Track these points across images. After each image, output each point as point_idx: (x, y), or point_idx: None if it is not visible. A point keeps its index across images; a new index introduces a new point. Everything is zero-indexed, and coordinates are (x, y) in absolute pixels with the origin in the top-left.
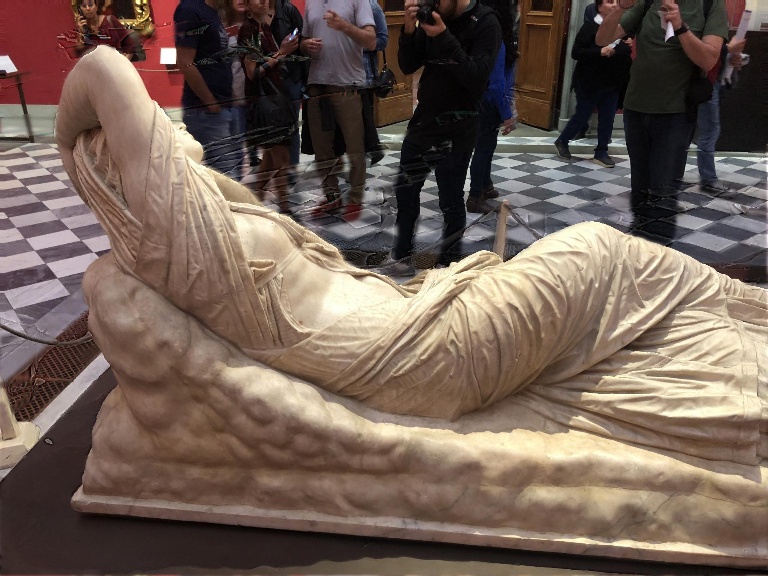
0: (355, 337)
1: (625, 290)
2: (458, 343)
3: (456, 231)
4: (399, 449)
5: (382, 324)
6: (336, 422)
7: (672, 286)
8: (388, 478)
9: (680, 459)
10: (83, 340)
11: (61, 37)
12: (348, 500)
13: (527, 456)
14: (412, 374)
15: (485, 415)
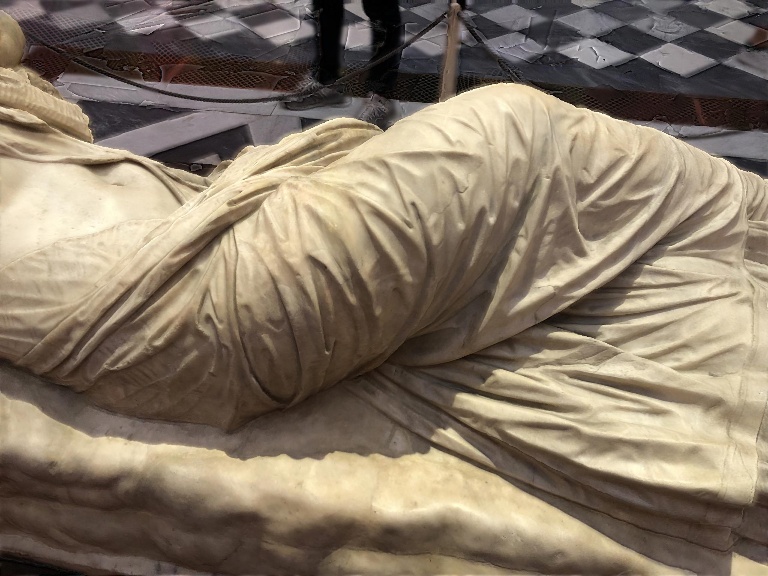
0: (37, 300)
1: (551, 225)
2: (216, 323)
3: (390, 51)
4: (124, 485)
5: (89, 277)
6: (9, 443)
7: (646, 216)
8: (123, 513)
9: (598, 526)
10: None
11: None
12: (69, 535)
13: (336, 509)
14: (143, 367)
15: (293, 418)
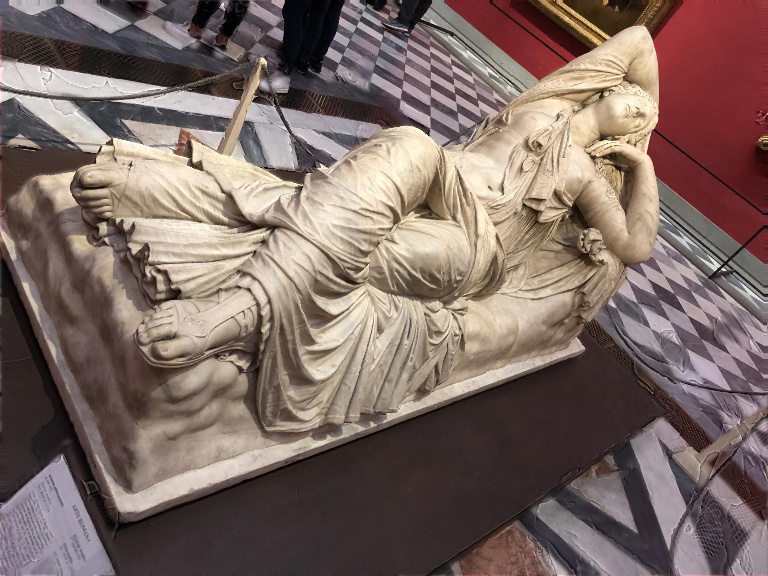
0: None
1: None
2: None
3: None
4: None
5: None
6: None
7: None
8: None
9: None
10: (615, 324)
11: (761, 111)
12: None
13: None
14: None
15: None
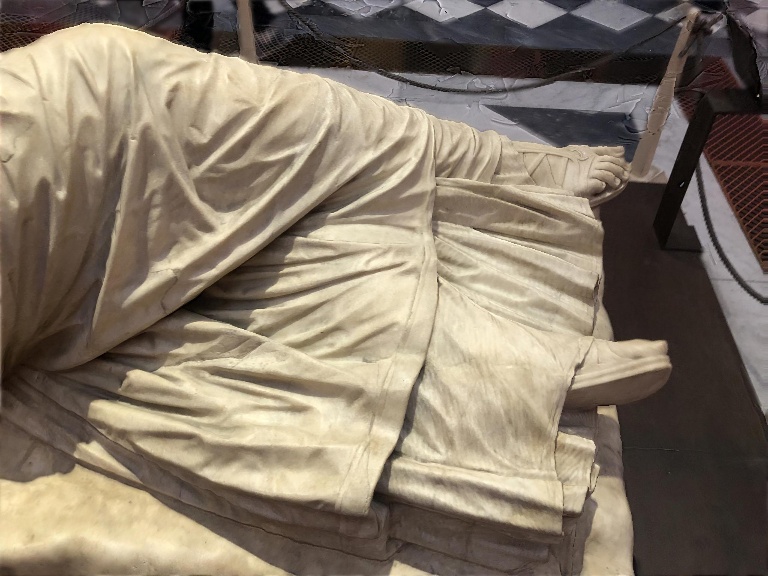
0: None
1: (156, 197)
2: None
3: (173, 4)
4: None
5: None
6: None
7: (284, 179)
8: None
9: (246, 544)
10: None
11: None
12: None
13: None
14: None
15: None
